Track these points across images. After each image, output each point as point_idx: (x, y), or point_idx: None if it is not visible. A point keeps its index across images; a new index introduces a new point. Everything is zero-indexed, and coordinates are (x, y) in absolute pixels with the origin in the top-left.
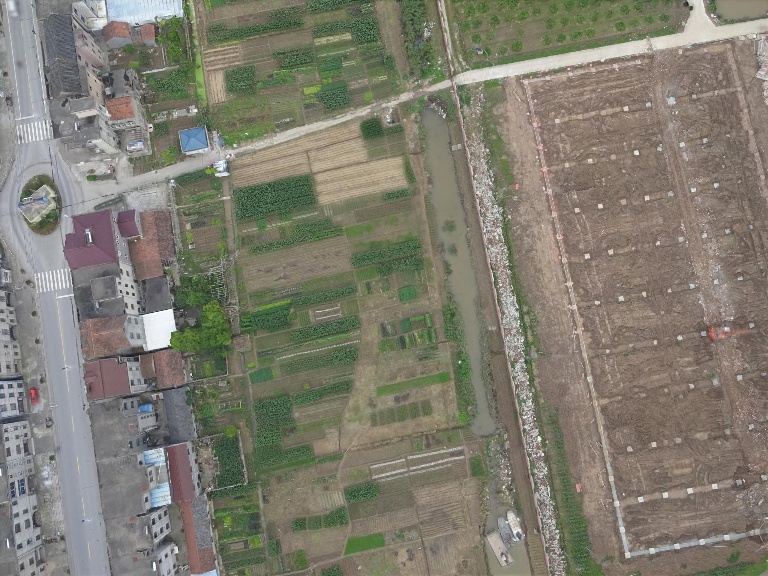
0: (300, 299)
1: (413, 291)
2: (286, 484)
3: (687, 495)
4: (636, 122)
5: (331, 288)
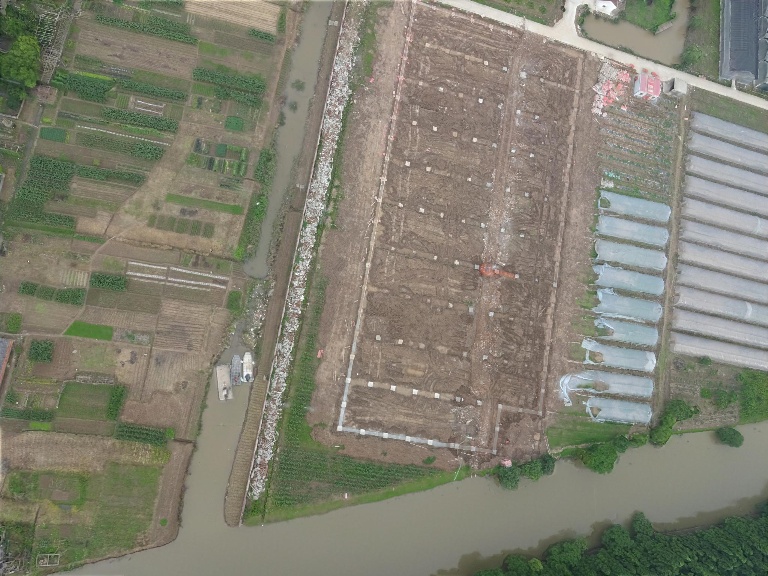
0: (127, 81)
1: (241, 123)
2: (32, 245)
3: (411, 395)
4: (490, 76)
5: (163, 87)
